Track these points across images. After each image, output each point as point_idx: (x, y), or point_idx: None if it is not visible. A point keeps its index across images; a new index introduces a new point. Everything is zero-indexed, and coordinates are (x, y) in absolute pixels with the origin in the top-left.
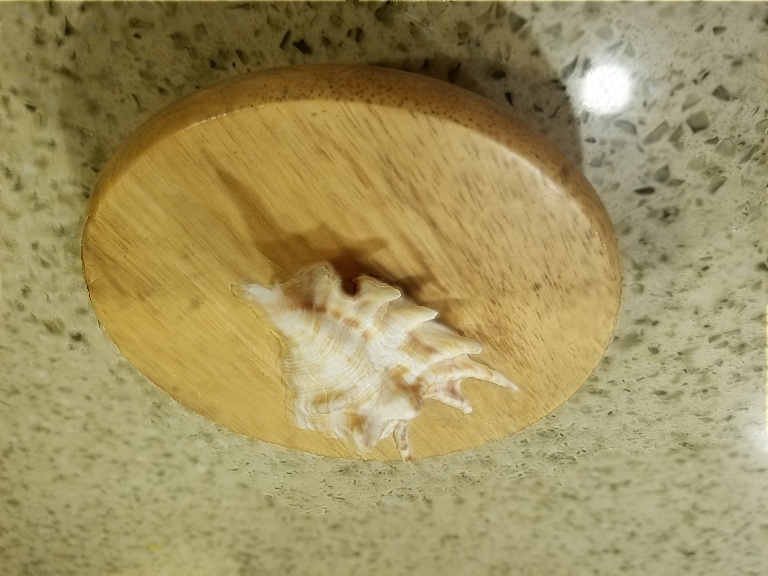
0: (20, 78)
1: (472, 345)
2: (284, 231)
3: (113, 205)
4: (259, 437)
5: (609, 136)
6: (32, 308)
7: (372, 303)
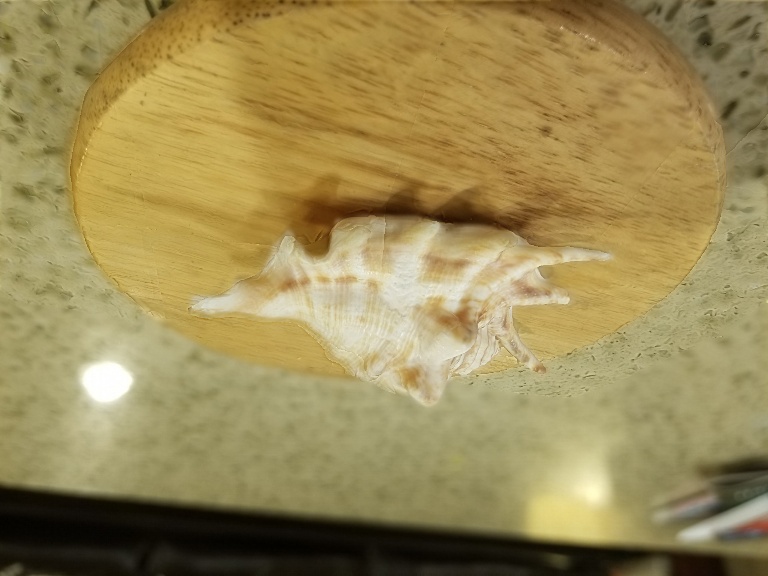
0: (37, 173)
1: (501, 240)
2: (242, 215)
3: (109, 262)
4: None
5: None
6: None
7: (349, 252)
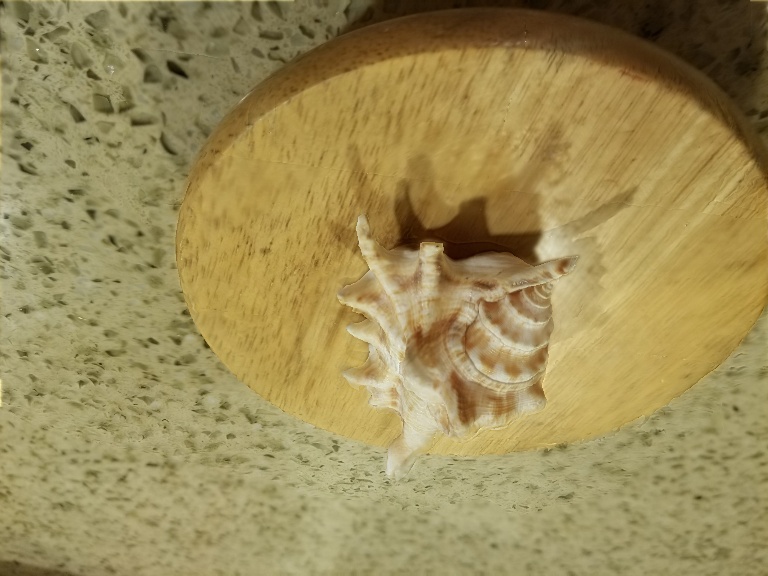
0: None
1: None
2: None
3: (464, 452)
4: (763, 286)
5: (186, 148)
6: (767, 360)
7: (367, 385)
